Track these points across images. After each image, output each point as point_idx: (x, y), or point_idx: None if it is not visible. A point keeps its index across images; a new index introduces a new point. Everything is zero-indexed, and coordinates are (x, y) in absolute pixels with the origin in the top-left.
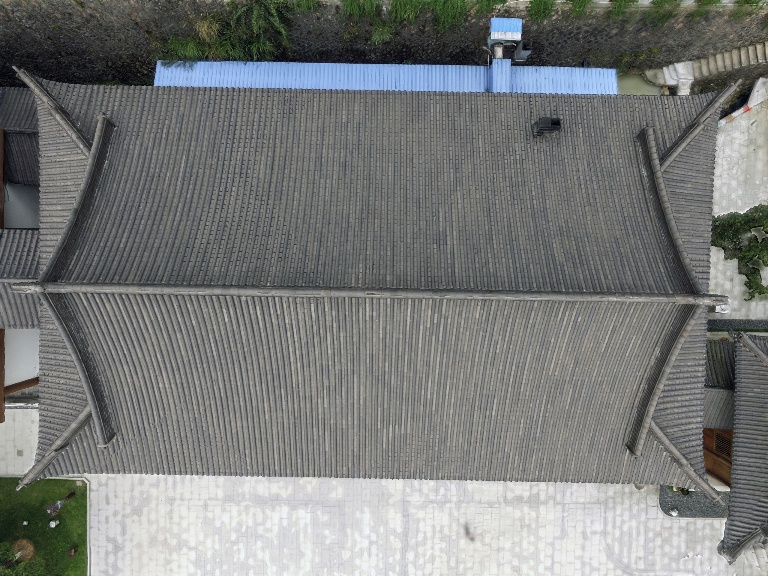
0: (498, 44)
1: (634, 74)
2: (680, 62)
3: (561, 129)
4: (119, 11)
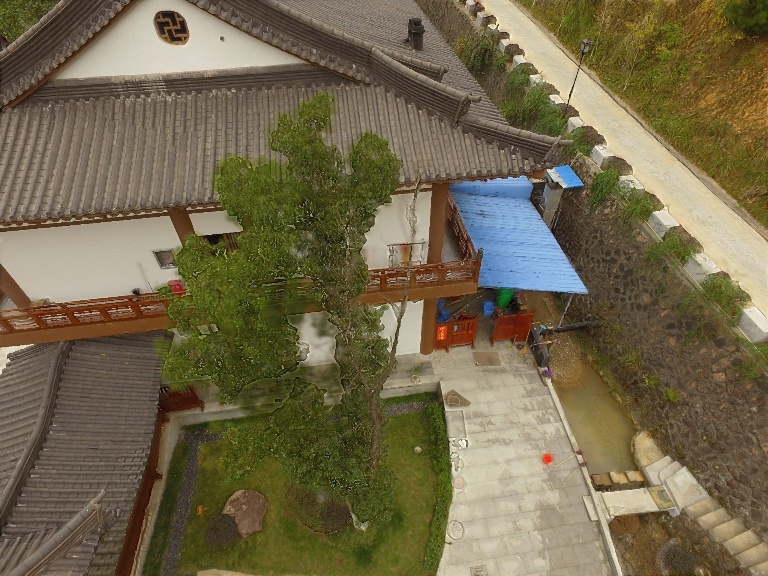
0: (545, 178)
1: (632, 420)
2: (694, 476)
3: None
4: None
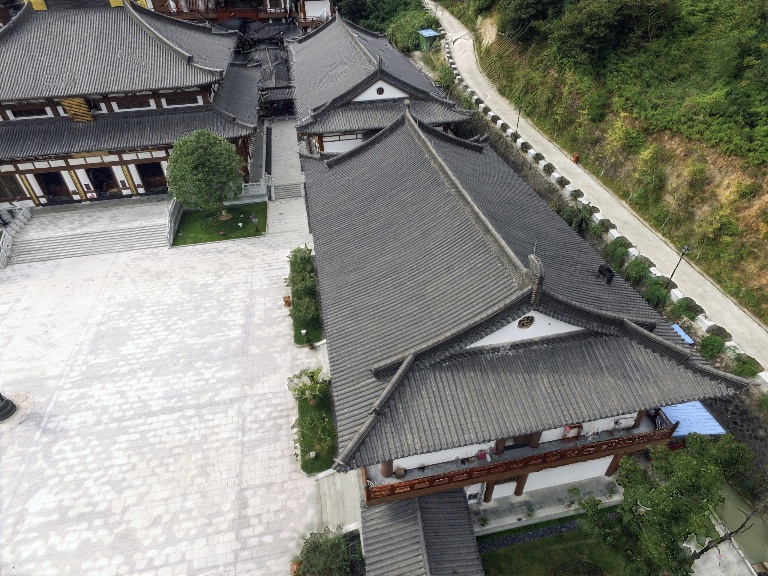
0: None
1: (763, 520)
2: None
3: (611, 289)
4: (537, 180)
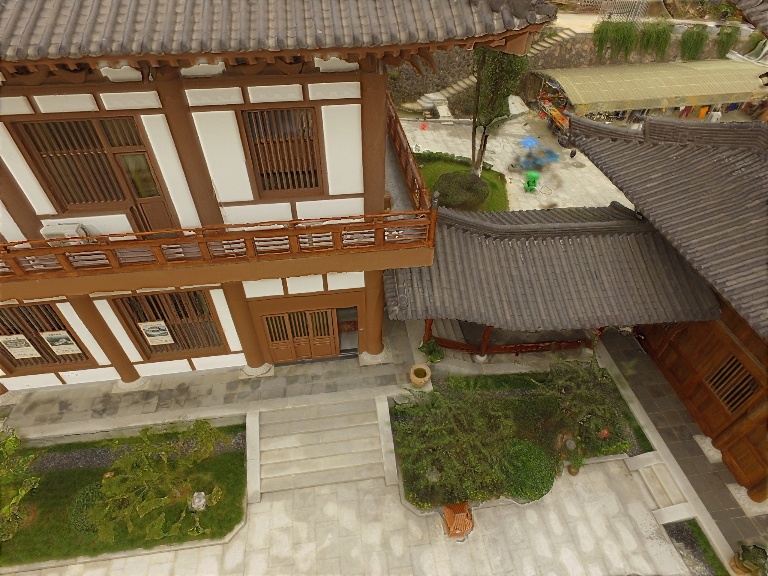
0: None
1: None
2: (429, 94)
3: None
4: None
